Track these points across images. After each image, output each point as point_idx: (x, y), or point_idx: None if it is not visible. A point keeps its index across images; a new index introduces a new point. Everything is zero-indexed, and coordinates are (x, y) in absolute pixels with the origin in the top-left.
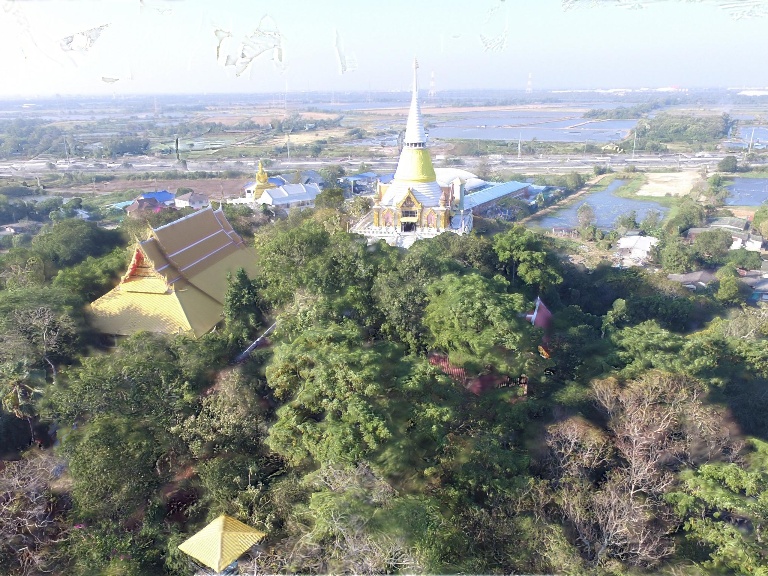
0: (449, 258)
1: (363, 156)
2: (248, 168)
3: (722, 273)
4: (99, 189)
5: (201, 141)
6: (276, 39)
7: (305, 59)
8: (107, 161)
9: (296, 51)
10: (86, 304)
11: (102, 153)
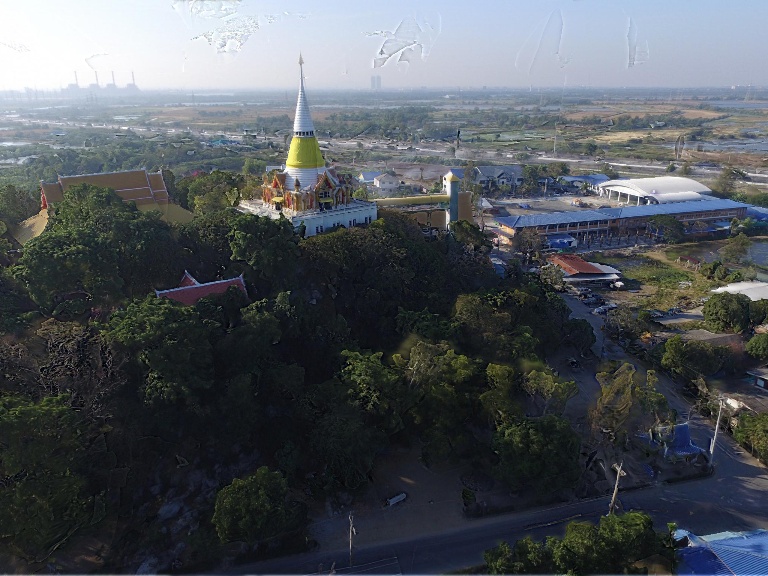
0: (137, 220)
1: (649, 159)
2: (506, 160)
3: (752, 342)
4: (364, 166)
5: (526, 133)
6: (416, 36)
7: (591, 52)
8: (411, 145)
9: (583, 44)
10: (4, 216)
11: (407, 137)
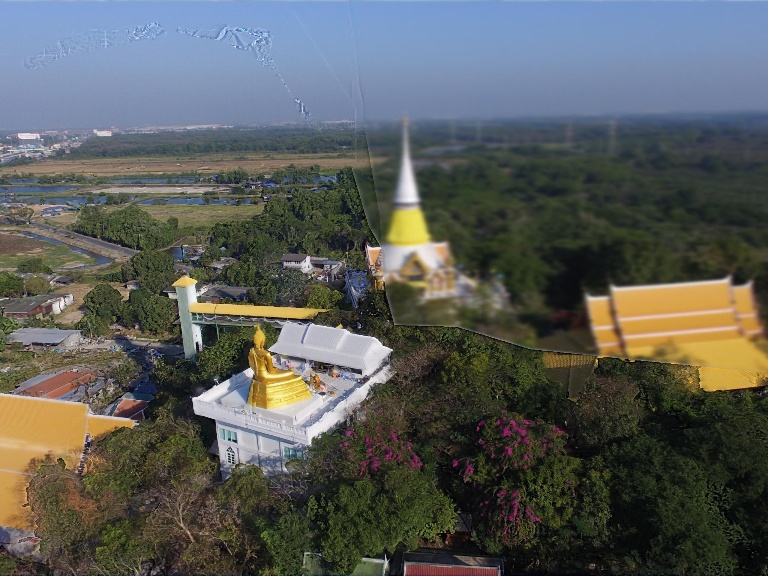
0: None
1: None
2: None
3: None
4: None
5: None
6: None
7: None
8: None
9: None
10: None
11: None
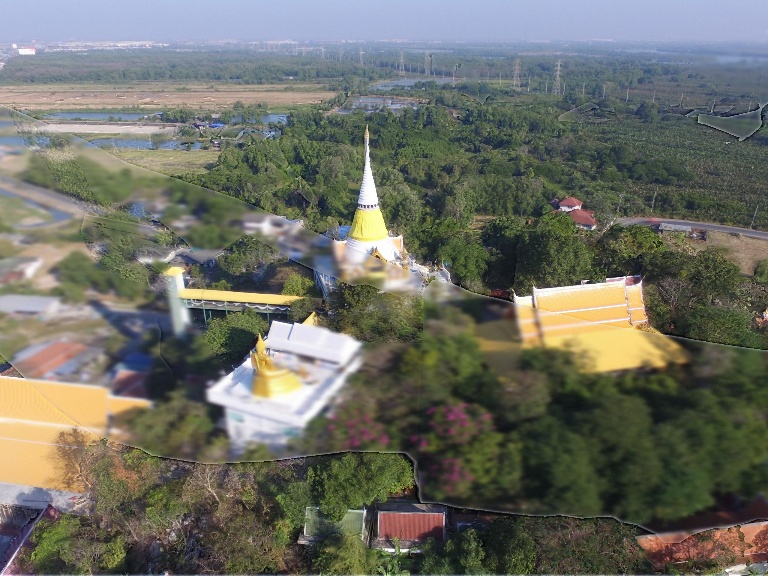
0: None
1: None
2: None
3: None
4: None
5: None
6: None
7: None
8: None
9: None
10: None
11: None
